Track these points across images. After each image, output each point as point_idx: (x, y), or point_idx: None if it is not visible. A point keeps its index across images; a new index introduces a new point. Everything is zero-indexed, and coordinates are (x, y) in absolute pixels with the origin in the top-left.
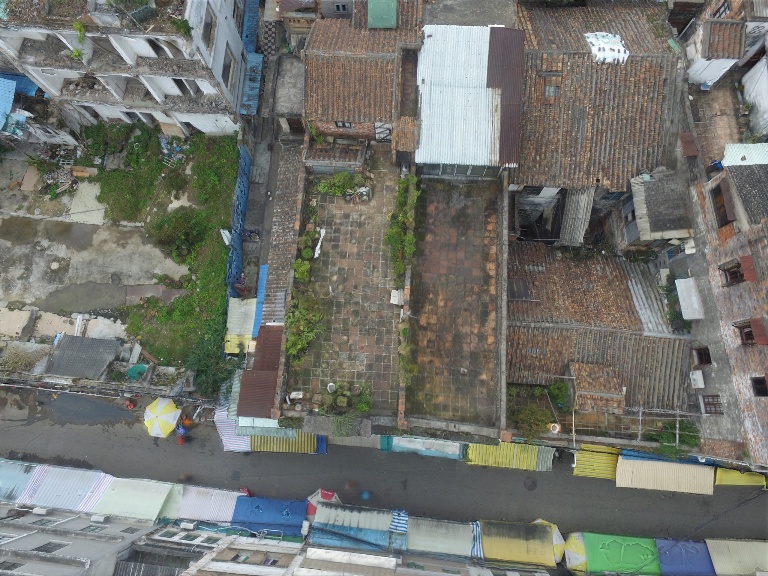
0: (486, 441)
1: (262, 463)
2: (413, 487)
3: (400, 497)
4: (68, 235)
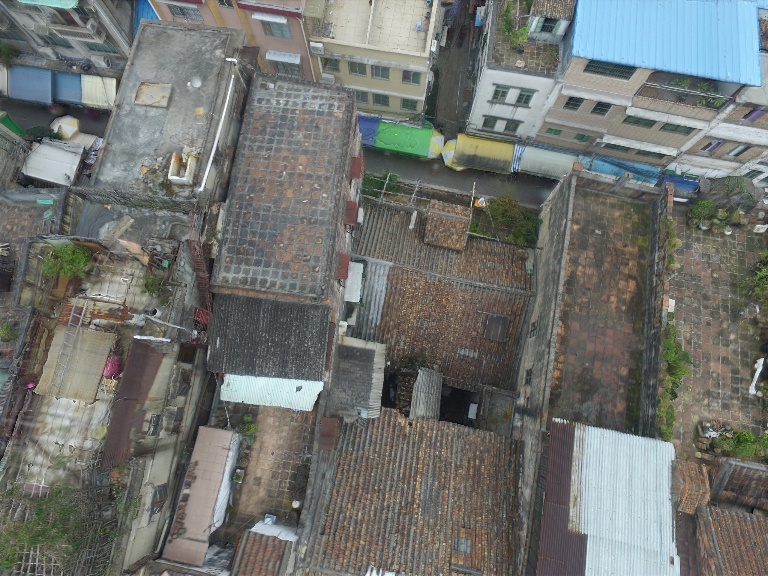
0: None
1: None
2: None
3: None
4: None
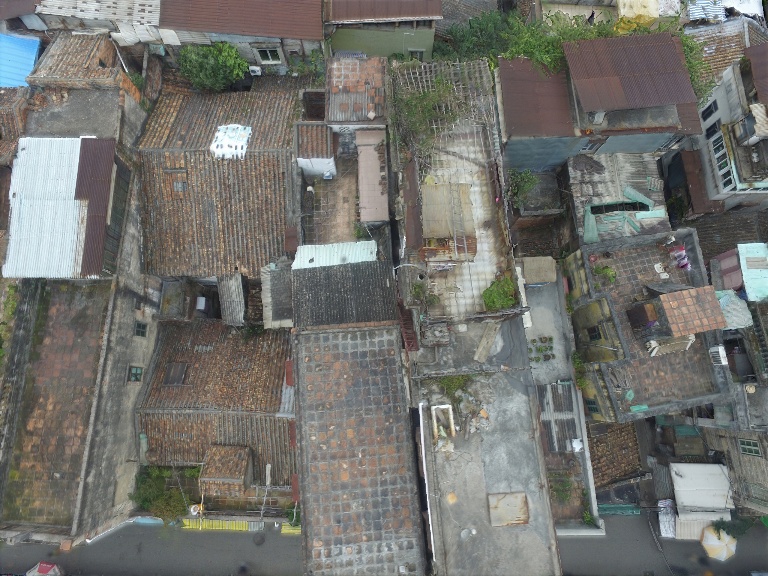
0: None
1: None
2: (147, 549)
3: (134, 560)
4: None
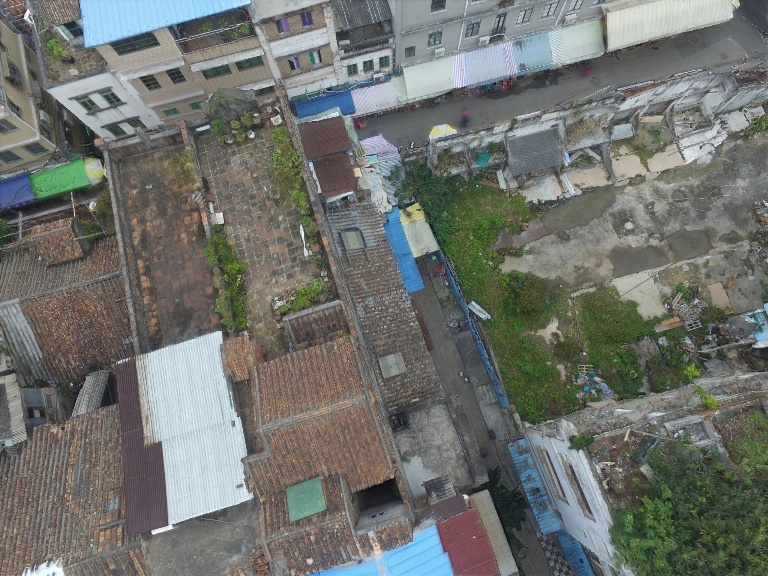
0: None
1: None
2: None
3: None
4: (638, 258)
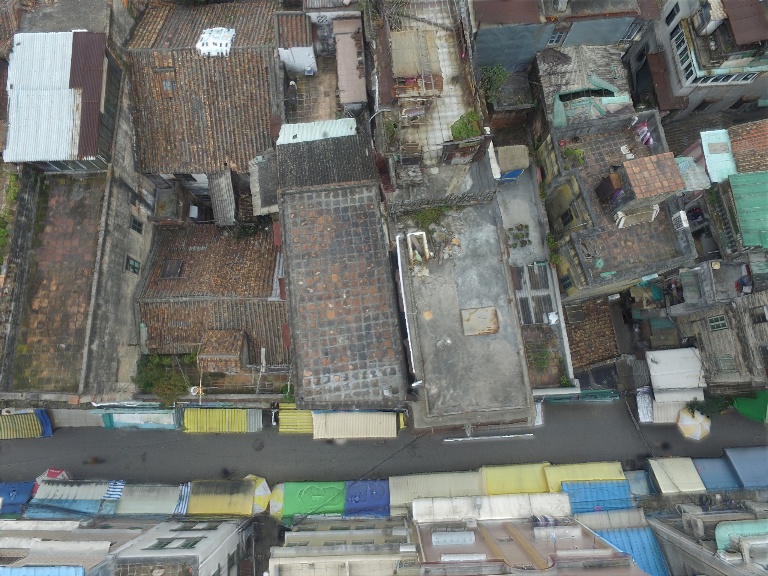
0: (81, 406)
1: (11, 451)
2: (151, 459)
3: (139, 469)
4: None
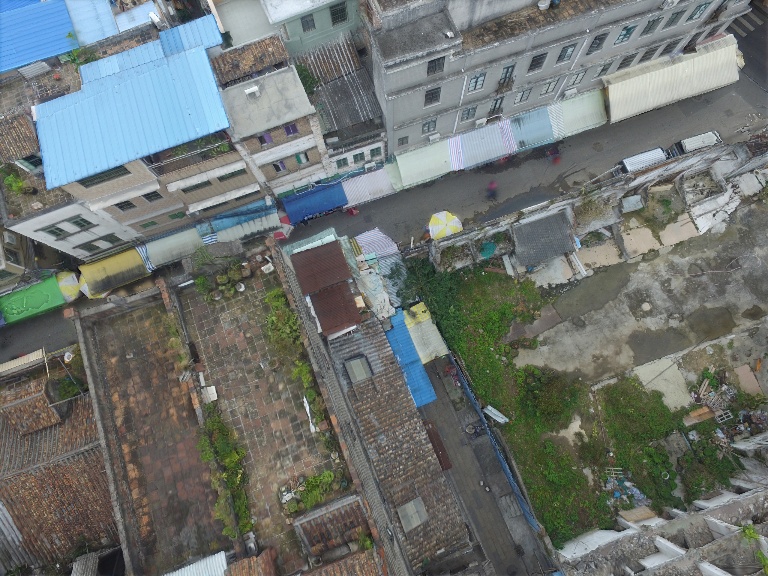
0: None
1: None
2: None
3: None
4: (659, 342)
